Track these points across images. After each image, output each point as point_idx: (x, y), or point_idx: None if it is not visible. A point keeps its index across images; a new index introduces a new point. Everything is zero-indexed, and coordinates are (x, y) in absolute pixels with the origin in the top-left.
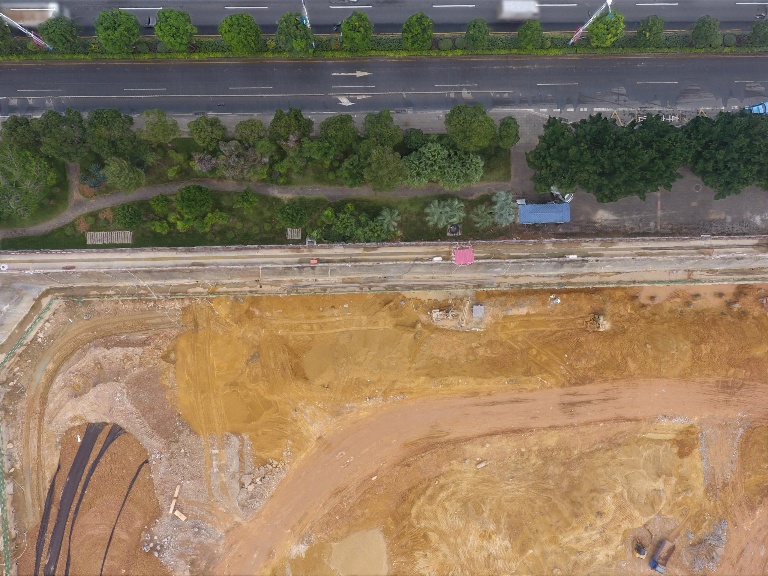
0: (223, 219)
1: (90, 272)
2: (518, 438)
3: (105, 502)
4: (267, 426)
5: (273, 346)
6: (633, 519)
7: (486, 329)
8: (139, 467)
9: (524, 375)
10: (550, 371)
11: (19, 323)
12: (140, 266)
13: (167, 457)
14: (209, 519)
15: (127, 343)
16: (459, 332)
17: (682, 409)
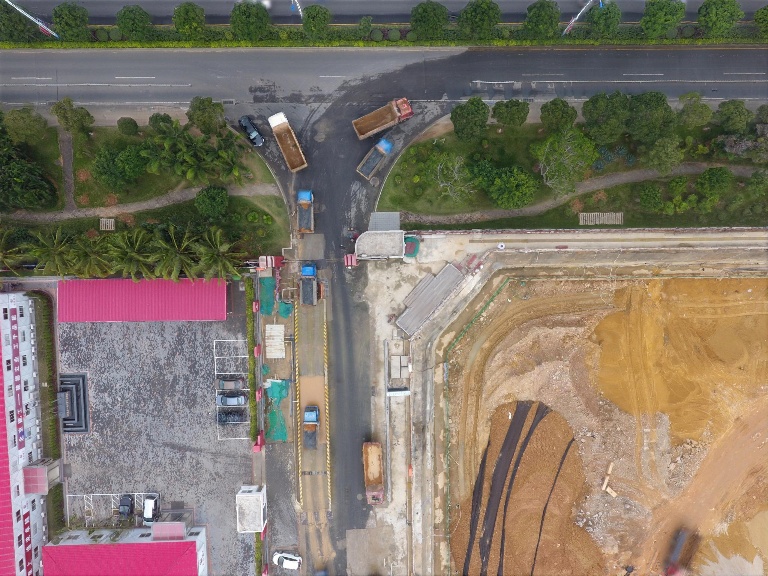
0: (741, 201)
1: (580, 252)
2: None
3: (538, 478)
4: (689, 406)
5: (681, 329)
6: None
7: None
8: (568, 444)
9: None
10: None
11: (470, 302)
12: (630, 246)
13: (602, 435)
14: (637, 496)
15: (562, 323)
16: None
17: None
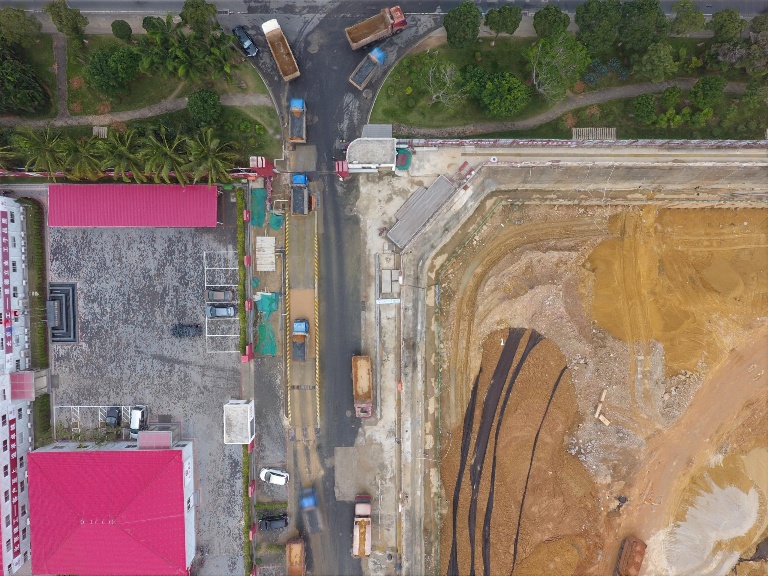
0: (735, 111)
1: (573, 167)
2: None
3: (530, 405)
4: (684, 336)
5: (676, 260)
6: None
7: None
8: (561, 372)
9: None
10: None
11: (463, 224)
12: None
13: (595, 361)
14: (630, 425)
15: (555, 249)
16: None
17: None
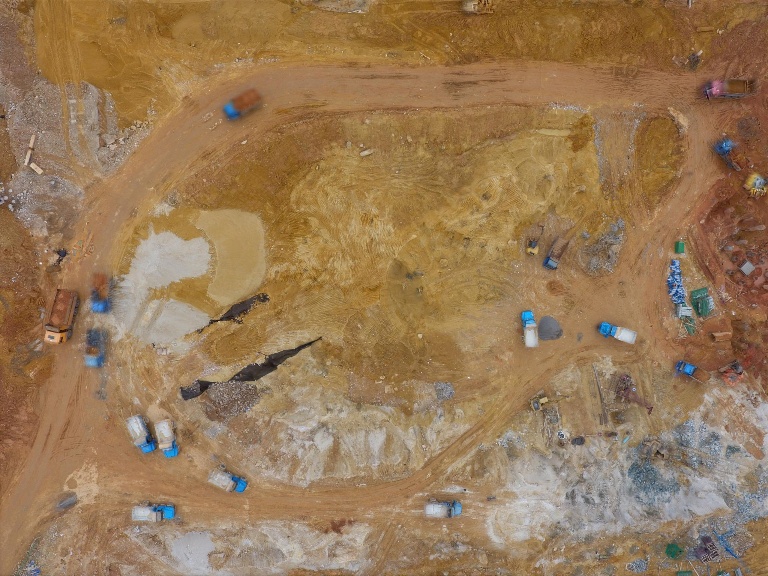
0: None
1: None
2: (400, 117)
3: None
4: (129, 82)
5: (140, 12)
6: (521, 203)
7: (369, 11)
8: None
9: (406, 50)
10: (434, 50)
11: None
12: None
13: (21, 105)
14: (67, 175)
15: None
16: (341, 13)
17: (574, 97)
